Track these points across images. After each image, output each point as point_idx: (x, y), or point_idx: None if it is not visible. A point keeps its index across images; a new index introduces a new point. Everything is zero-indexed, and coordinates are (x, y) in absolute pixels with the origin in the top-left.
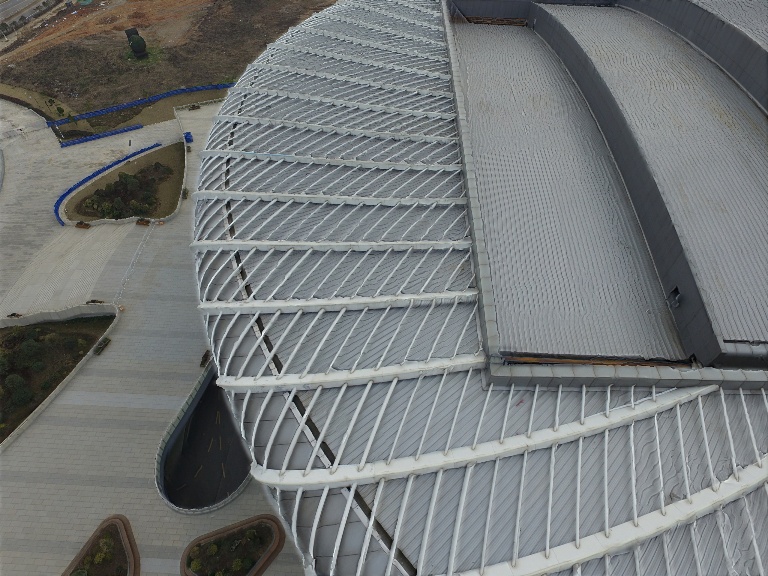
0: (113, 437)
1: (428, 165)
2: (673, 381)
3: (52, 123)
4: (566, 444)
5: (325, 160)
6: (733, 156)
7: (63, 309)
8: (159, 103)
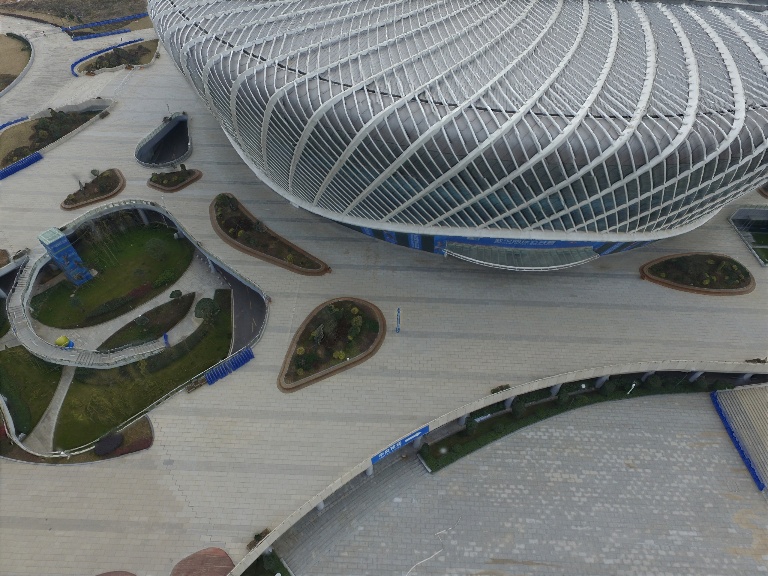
0: (112, 146)
1: None
2: None
3: (65, 29)
4: None
5: None
6: None
7: (80, 102)
8: (143, 19)
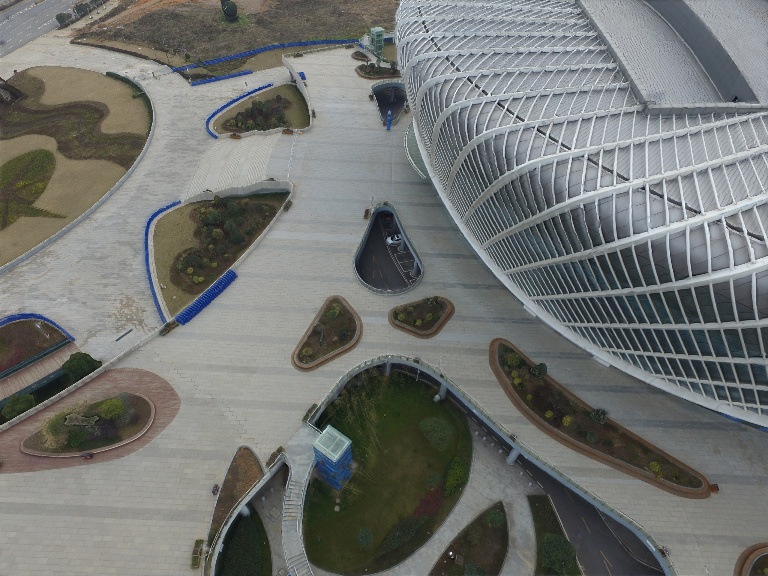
0: (316, 256)
1: (575, 32)
2: (746, 109)
3: (176, 69)
4: (694, 134)
5: (505, 32)
6: (765, 31)
7: (248, 185)
8: (259, 56)
